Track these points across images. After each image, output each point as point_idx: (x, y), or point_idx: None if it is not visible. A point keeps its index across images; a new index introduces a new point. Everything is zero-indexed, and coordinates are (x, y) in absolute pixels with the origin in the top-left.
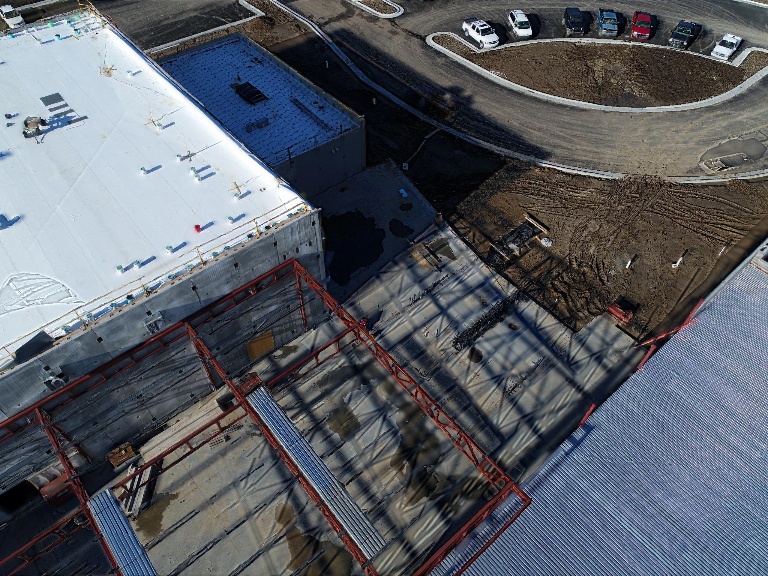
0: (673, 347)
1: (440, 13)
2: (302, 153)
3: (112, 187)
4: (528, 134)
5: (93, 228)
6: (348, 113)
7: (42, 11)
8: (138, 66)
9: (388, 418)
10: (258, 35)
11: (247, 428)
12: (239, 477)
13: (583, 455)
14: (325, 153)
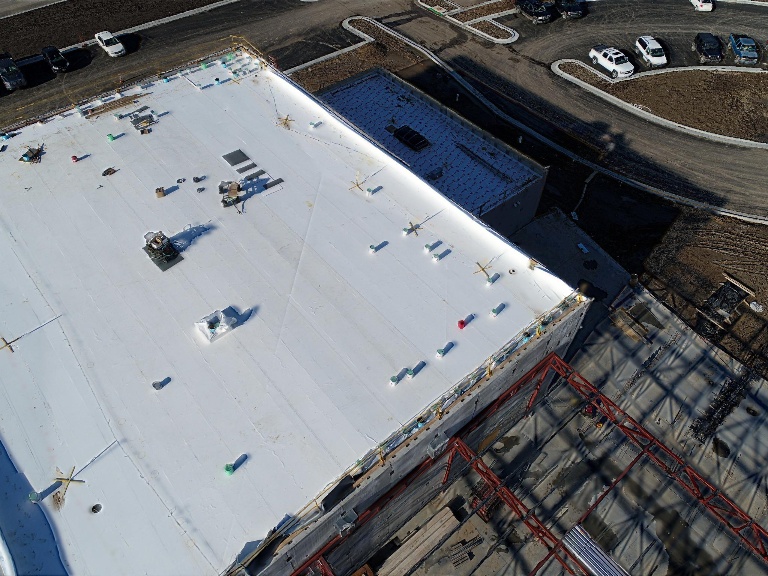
0: None
1: (558, 38)
2: (490, 210)
3: (342, 270)
4: (693, 177)
5: (340, 324)
6: (527, 162)
7: (139, 37)
8: (316, 116)
9: (646, 529)
10: (373, 63)
11: (490, 542)
12: None
13: None
14: (508, 208)
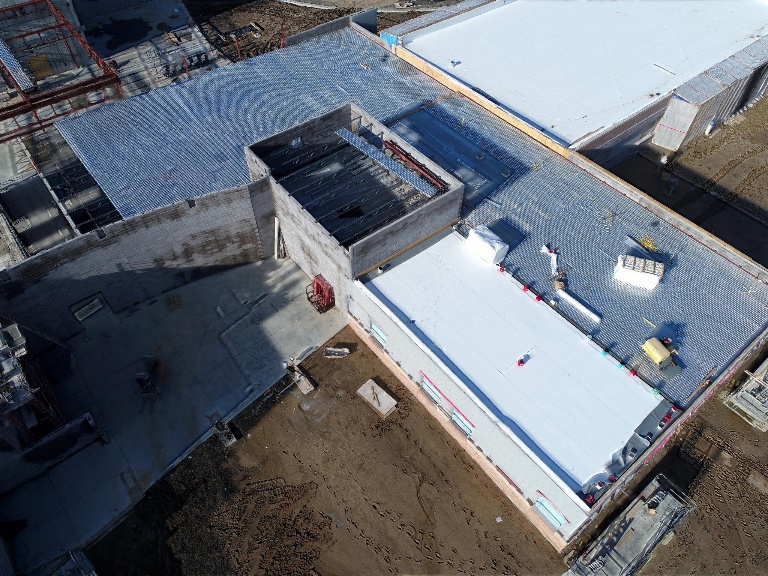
0: (268, 55)
1: None
2: None
3: None
4: None
5: None
6: None
7: None
8: None
9: None
10: None
11: None
12: (8, 121)
13: (180, 87)
14: None
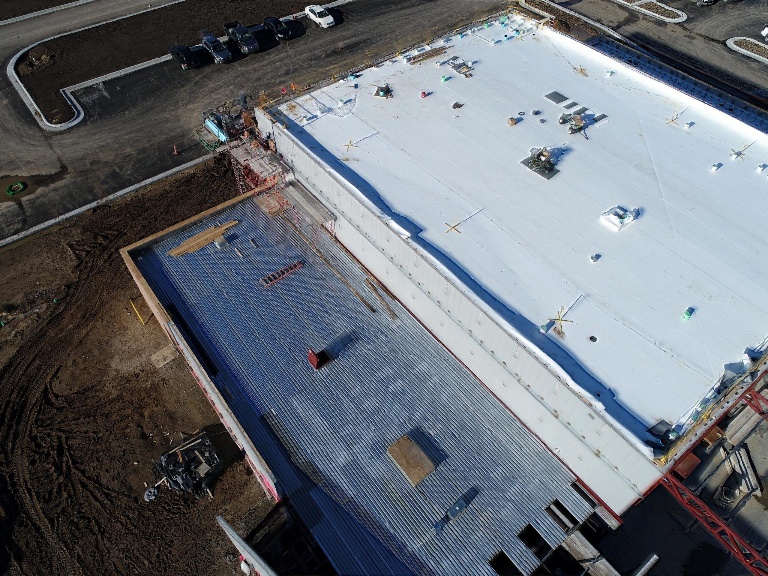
0: None
1: (724, 18)
2: None
3: (695, 182)
4: None
5: (716, 221)
6: None
7: (340, 11)
8: (606, 67)
9: None
10: None
11: None
12: None
13: None
14: None
